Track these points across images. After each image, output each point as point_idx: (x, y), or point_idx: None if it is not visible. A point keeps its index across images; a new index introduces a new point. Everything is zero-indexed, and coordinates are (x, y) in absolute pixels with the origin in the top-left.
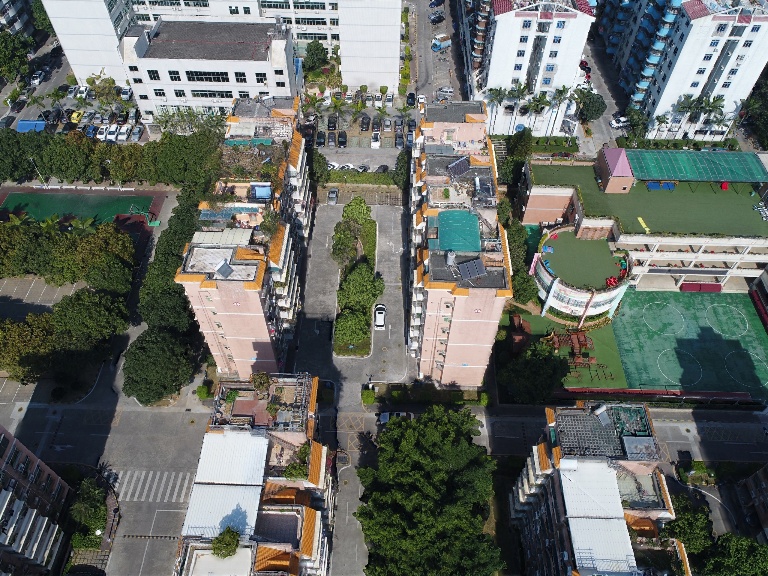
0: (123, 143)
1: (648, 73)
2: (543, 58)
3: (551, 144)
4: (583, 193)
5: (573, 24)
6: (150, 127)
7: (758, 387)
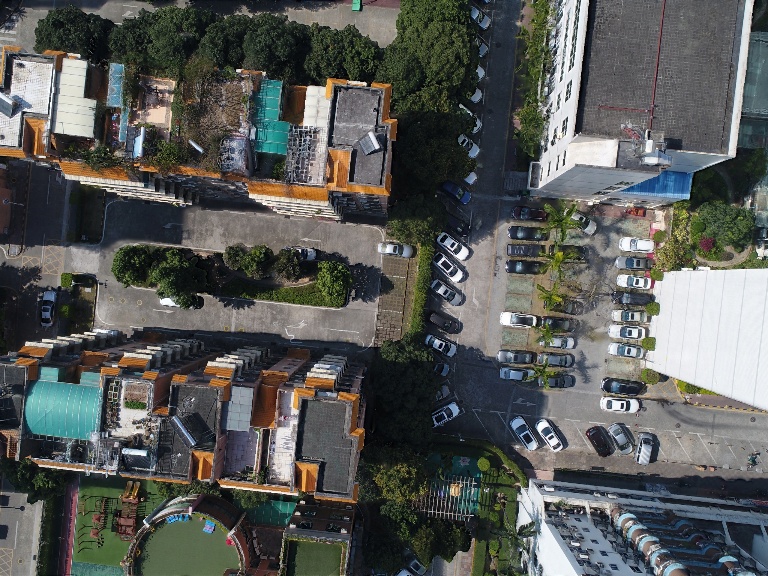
0: None
1: None
2: None
3: None
4: None
5: None
6: None
7: None
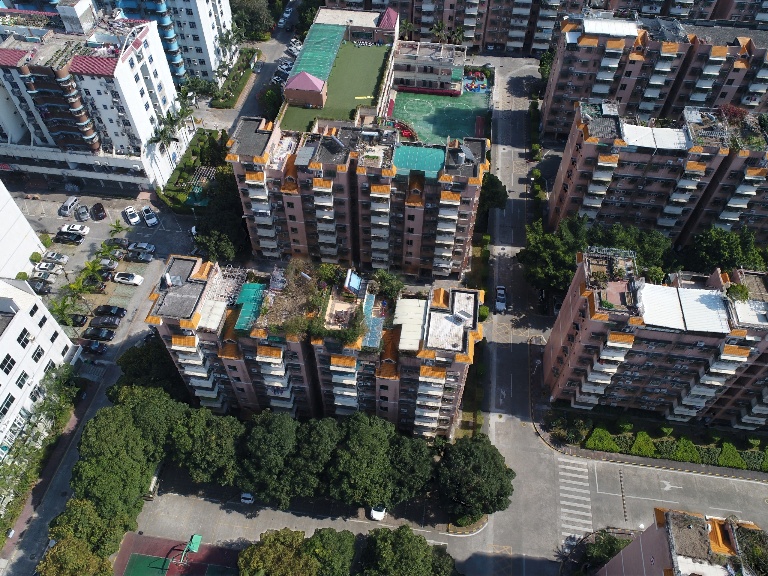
0: None
1: (175, 47)
2: (153, 83)
3: (202, 145)
4: None
5: (150, 37)
6: None
7: (472, 111)
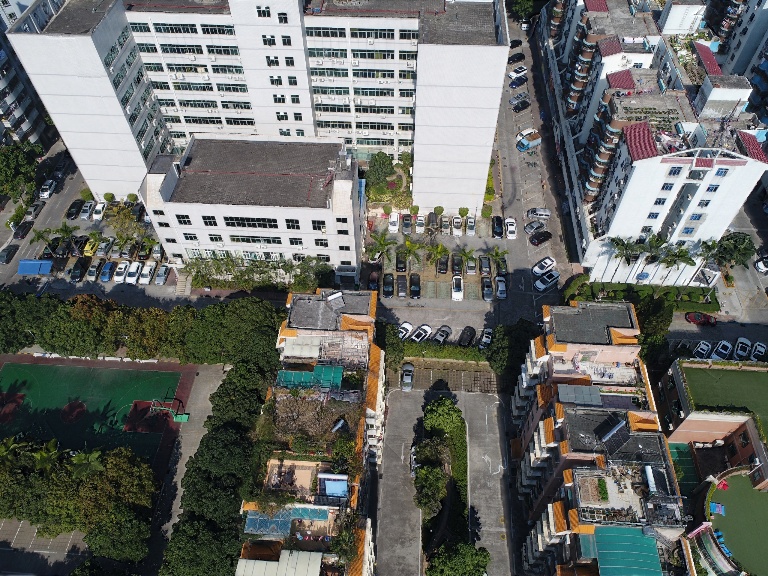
0: (145, 287)
1: None
2: (689, 207)
3: (684, 299)
4: (762, 421)
5: (739, 172)
6: (178, 269)
7: None
